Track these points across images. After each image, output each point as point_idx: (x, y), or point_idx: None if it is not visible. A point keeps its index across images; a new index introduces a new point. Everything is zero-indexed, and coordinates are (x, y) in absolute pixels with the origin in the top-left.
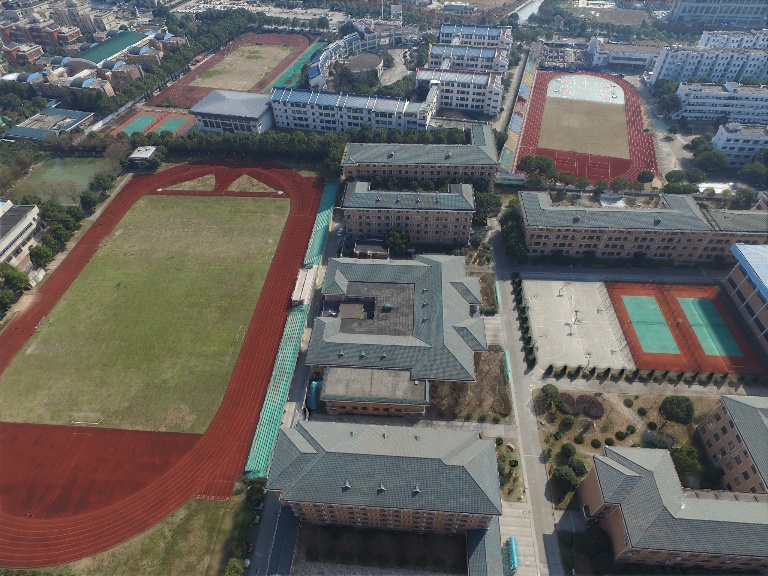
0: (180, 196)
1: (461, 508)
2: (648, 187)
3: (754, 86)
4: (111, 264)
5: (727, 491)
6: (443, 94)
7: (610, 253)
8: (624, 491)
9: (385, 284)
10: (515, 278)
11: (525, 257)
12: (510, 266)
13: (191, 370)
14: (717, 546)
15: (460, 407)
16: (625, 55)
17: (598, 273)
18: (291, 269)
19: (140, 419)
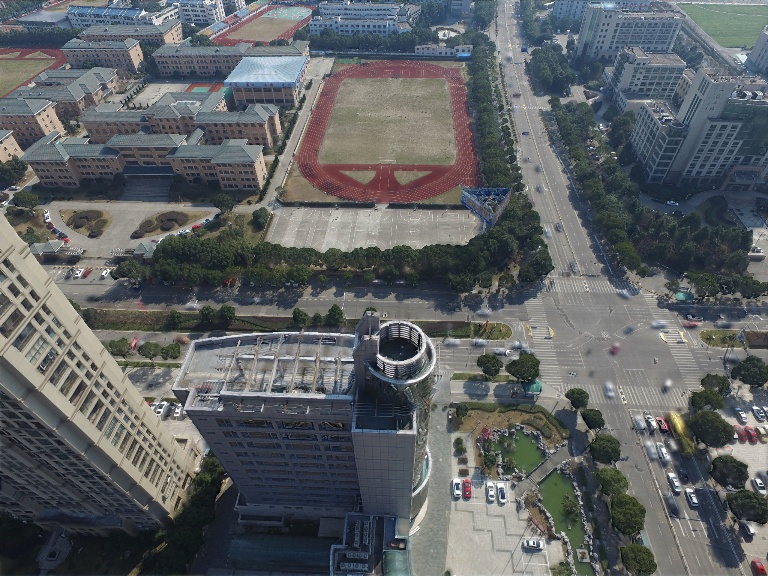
0: None
1: (19, 113)
2: None
3: (362, 3)
4: None
5: (132, 111)
6: (185, 13)
7: (204, 72)
8: (89, 110)
9: (66, 78)
10: (147, 82)
11: (156, 73)
12: (151, 79)
13: None
14: (109, 119)
15: (70, 113)
16: None
17: (193, 81)
18: None
19: None
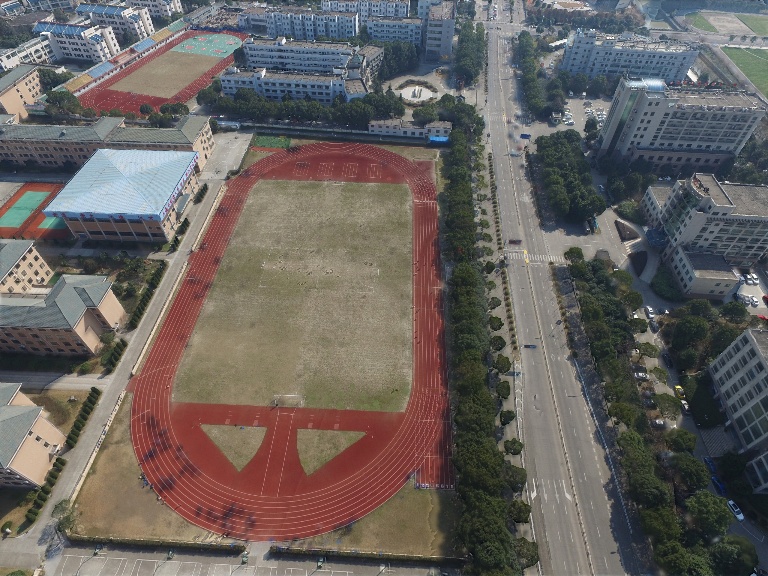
0: None
1: None
2: None
3: (303, 41)
4: None
5: None
6: (60, 45)
7: (49, 162)
8: None
9: None
10: None
11: None
12: None
13: None
14: None
15: None
16: (260, 17)
17: (30, 177)
18: None
19: None
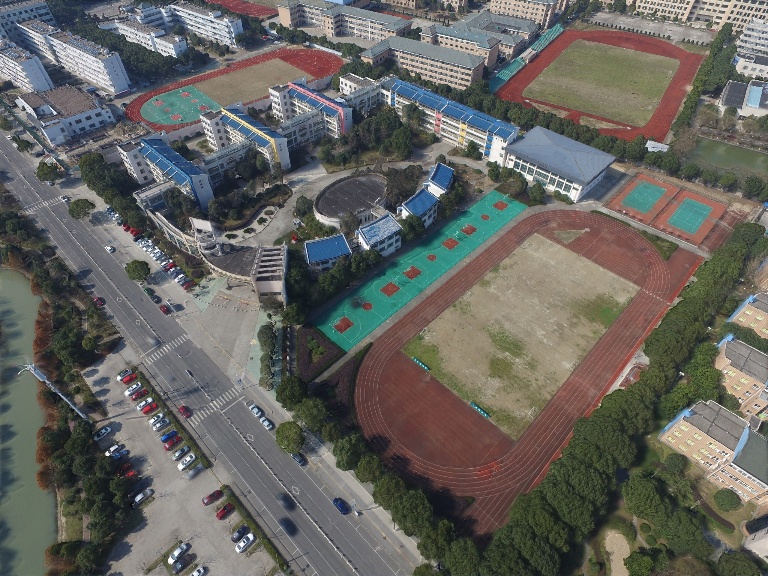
0: (609, 118)
1: None
2: (300, 46)
3: (140, 32)
4: (645, 92)
5: None
6: None
7: None
8: None
9: None
10: None
11: None
12: None
13: (586, 50)
14: None
15: None
16: None
17: None
18: (533, 66)
19: (605, 45)
